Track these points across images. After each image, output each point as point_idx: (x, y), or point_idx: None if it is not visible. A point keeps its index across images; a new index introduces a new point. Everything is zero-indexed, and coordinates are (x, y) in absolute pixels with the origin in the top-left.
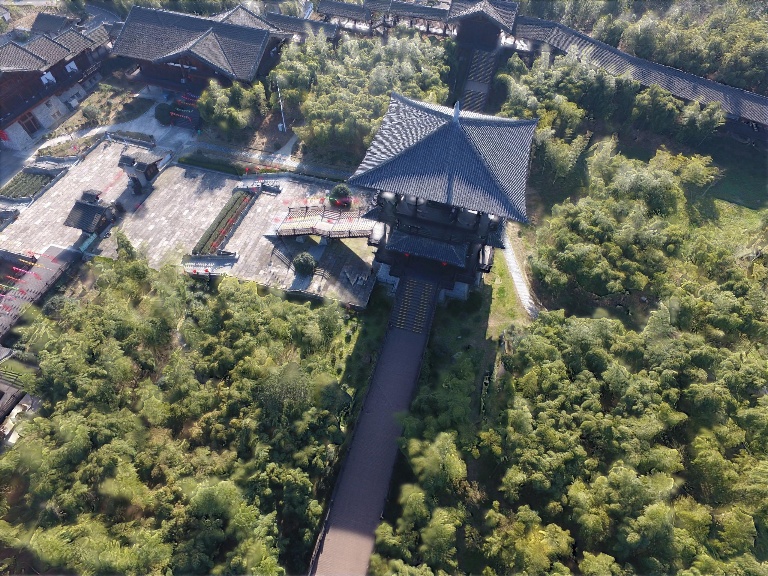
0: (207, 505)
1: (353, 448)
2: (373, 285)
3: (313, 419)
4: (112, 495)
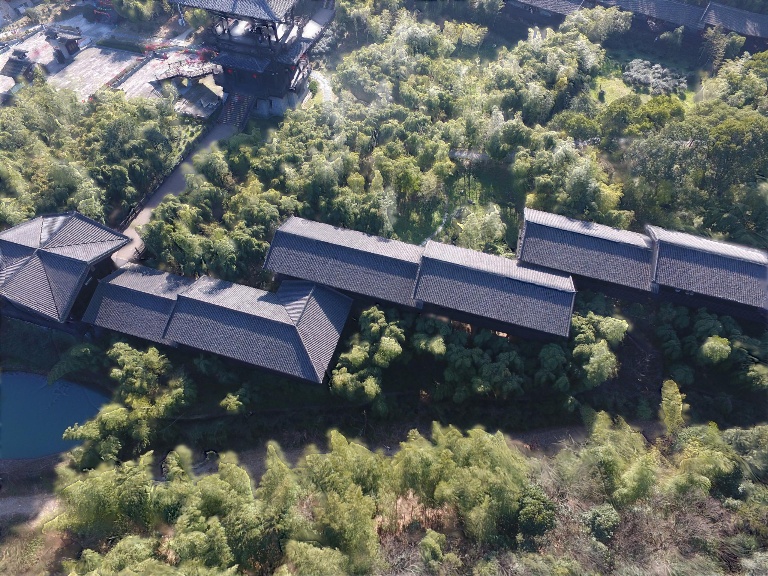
0: (57, 175)
1: (171, 176)
2: (218, 106)
3: (136, 143)
4: (5, 189)
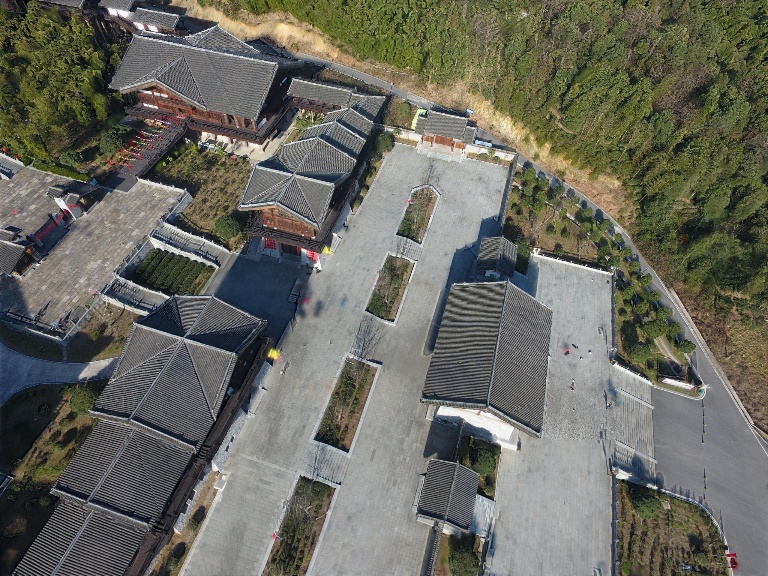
0: None
1: None
2: None
3: None
4: None
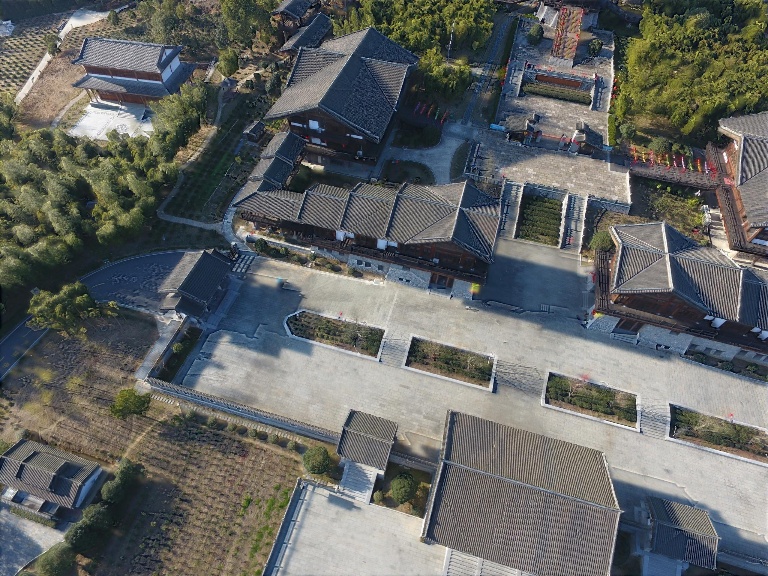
0: None
1: None
2: (598, 29)
3: None
4: None
